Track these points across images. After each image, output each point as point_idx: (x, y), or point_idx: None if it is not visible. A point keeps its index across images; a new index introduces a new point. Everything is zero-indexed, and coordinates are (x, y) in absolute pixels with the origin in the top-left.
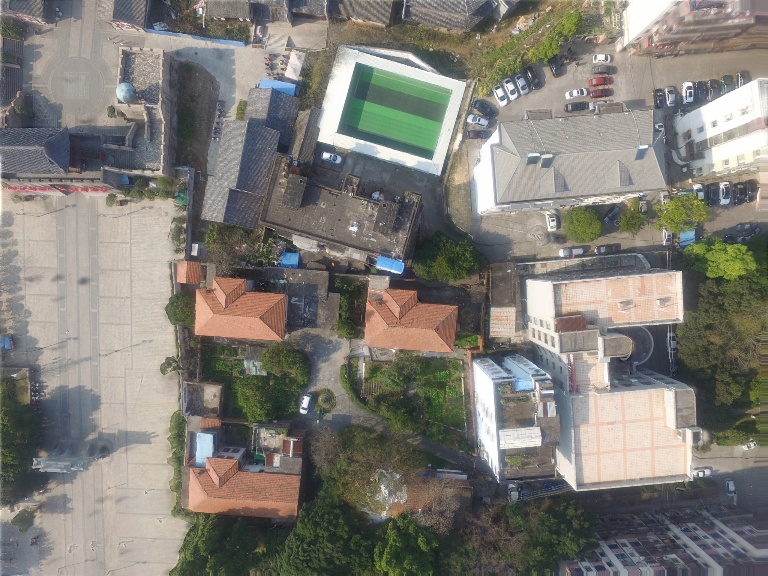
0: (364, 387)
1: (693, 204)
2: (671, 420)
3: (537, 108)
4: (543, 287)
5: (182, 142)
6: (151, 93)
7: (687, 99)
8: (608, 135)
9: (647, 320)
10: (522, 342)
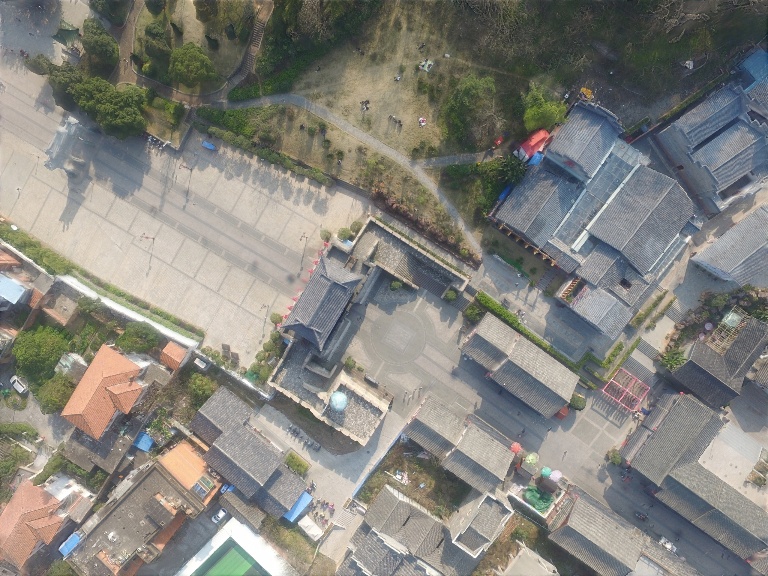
0: (5, 446)
1: None
2: None
3: None
4: None
5: None
6: (339, 412)
7: None
8: None
9: None
10: None
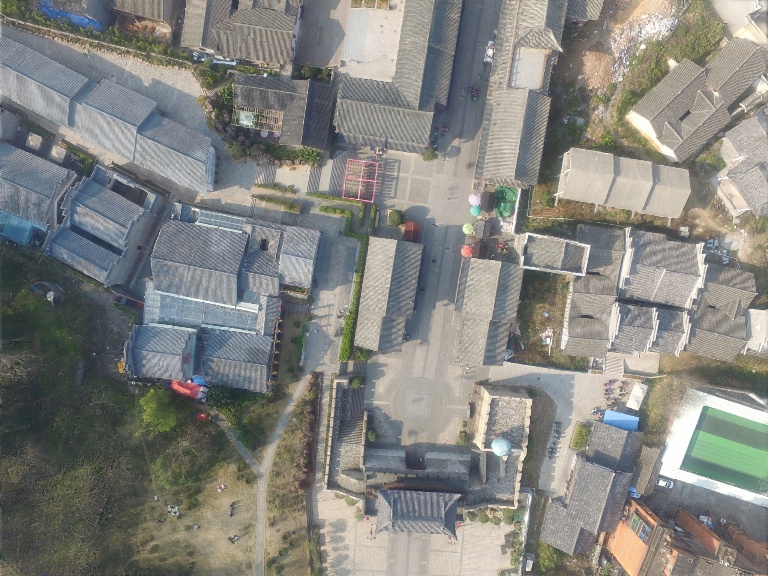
0: None
1: None
2: None
3: None
4: None
5: None
6: (512, 435)
7: None
8: None
9: None
10: None
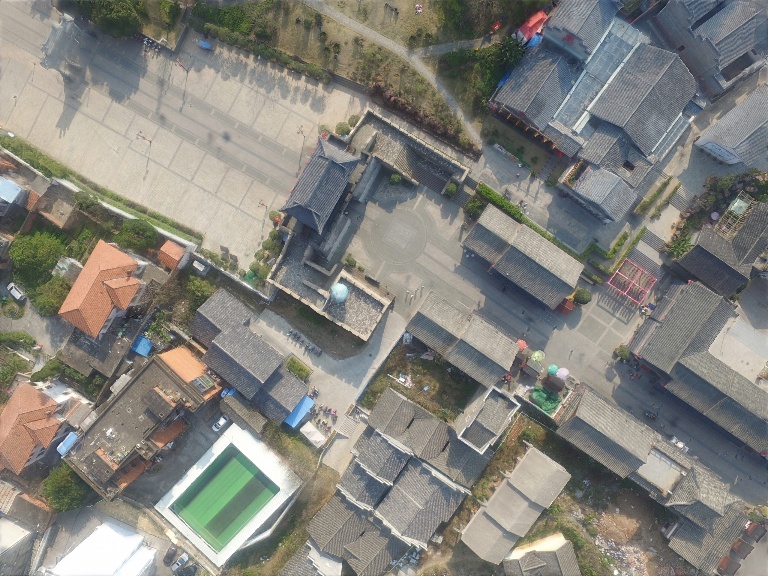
0: (2, 353)
1: None
2: None
3: None
4: None
5: None
6: (339, 308)
7: None
8: None
9: None
10: None
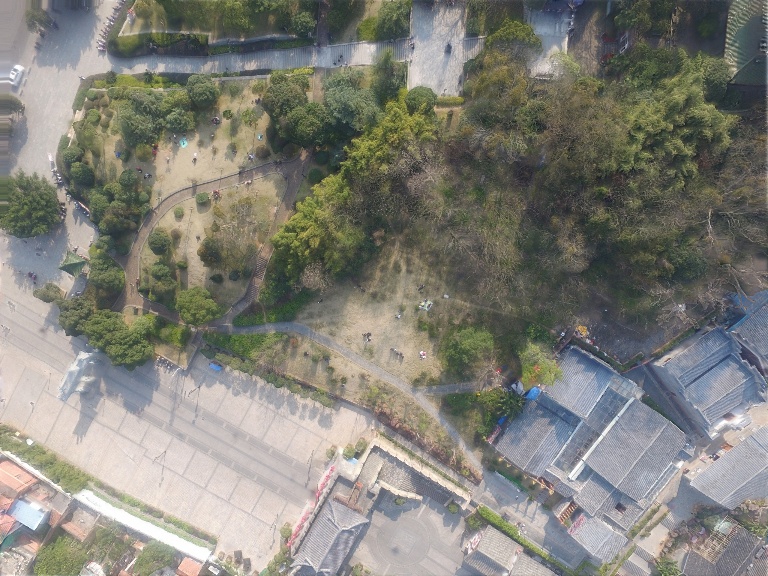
0: None
1: None
2: None
3: None
4: None
5: None
6: None
7: None
8: None
9: None
10: None
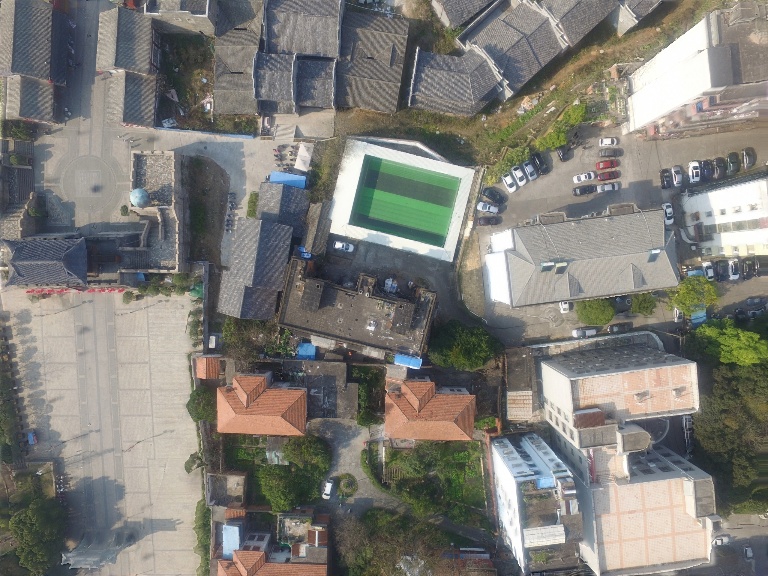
0: (385, 473)
1: (704, 288)
2: (691, 508)
3: (546, 192)
4: (560, 379)
5: (195, 235)
6: (164, 194)
7: (694, 179)
8: (620, 238)
9: (664, 410)
10: (539, 421)
